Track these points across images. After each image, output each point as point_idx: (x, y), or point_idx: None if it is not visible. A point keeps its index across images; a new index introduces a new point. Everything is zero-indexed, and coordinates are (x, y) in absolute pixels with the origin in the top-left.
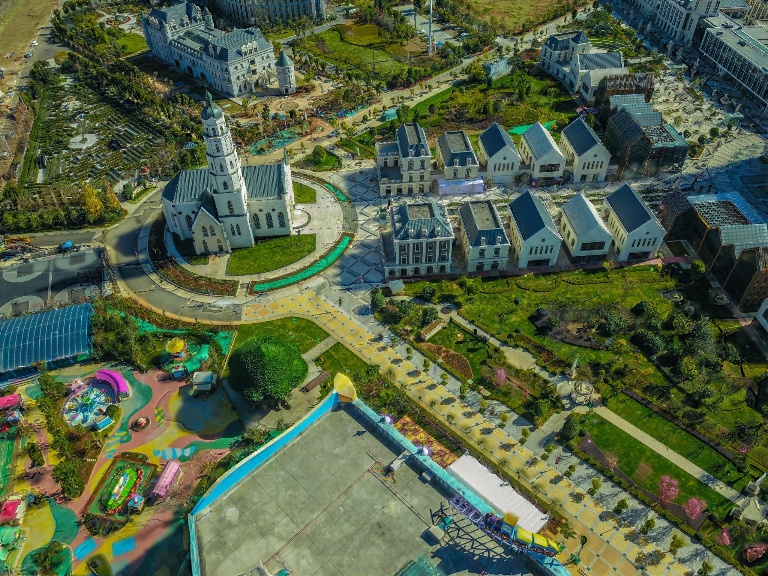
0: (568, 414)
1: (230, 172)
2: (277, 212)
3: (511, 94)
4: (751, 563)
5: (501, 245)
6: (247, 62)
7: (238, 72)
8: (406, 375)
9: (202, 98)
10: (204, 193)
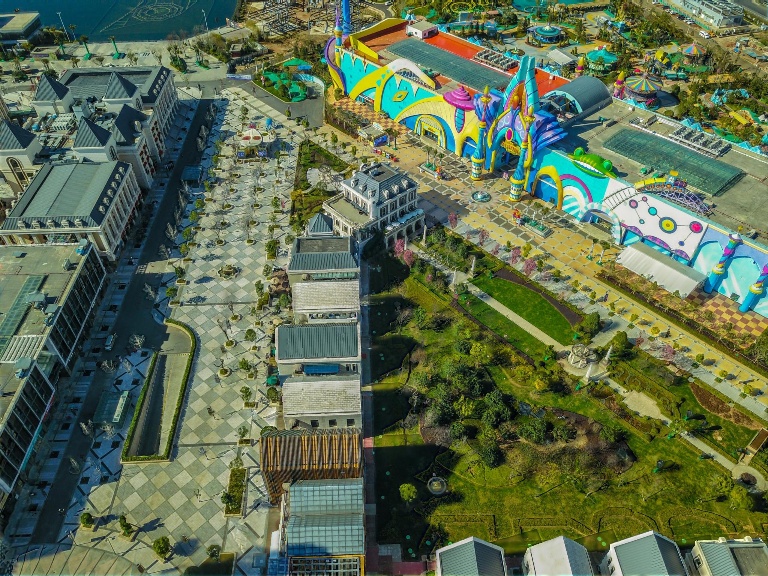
0: (591, 345)
1: None
2: None
3: None
4: (475, 253)
5: (712, 541)
6: None
7: None
8: (764, 391)
9: None
10: None
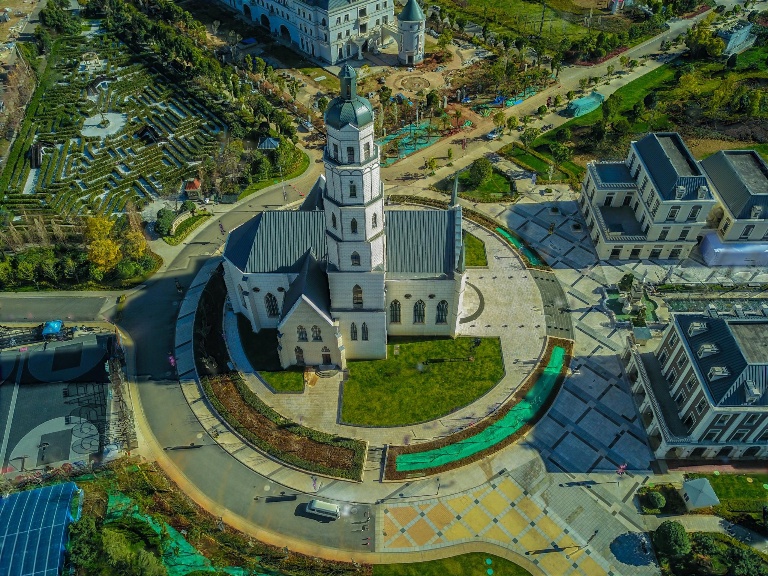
0: None
1: (369, 234)
2: (438, 300)
3: (767, 81)
4: None
5: None
6: (355, 12)
7: (341, 27)
8: None
9: (283, 64)
10: (304, 258)
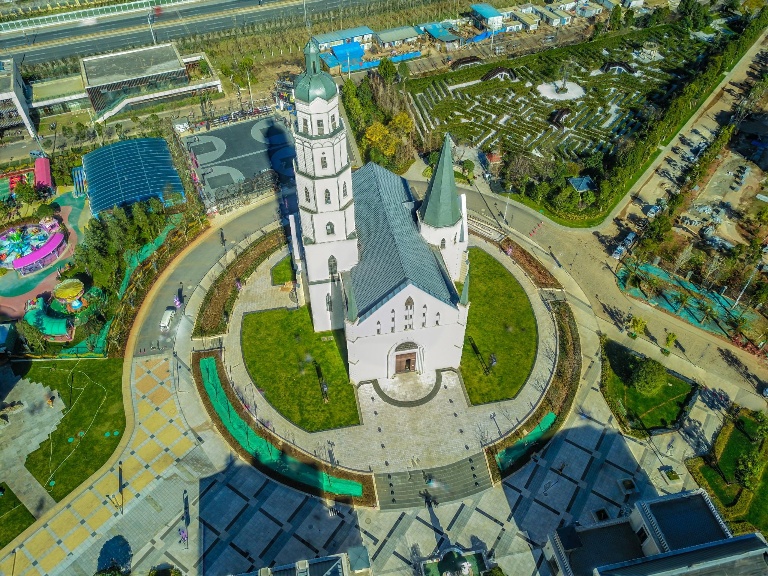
0: None
1: (304, 203)
2: None
3: None
4: None
5: None
6: None
7: None
8: None
9: None
10: None
